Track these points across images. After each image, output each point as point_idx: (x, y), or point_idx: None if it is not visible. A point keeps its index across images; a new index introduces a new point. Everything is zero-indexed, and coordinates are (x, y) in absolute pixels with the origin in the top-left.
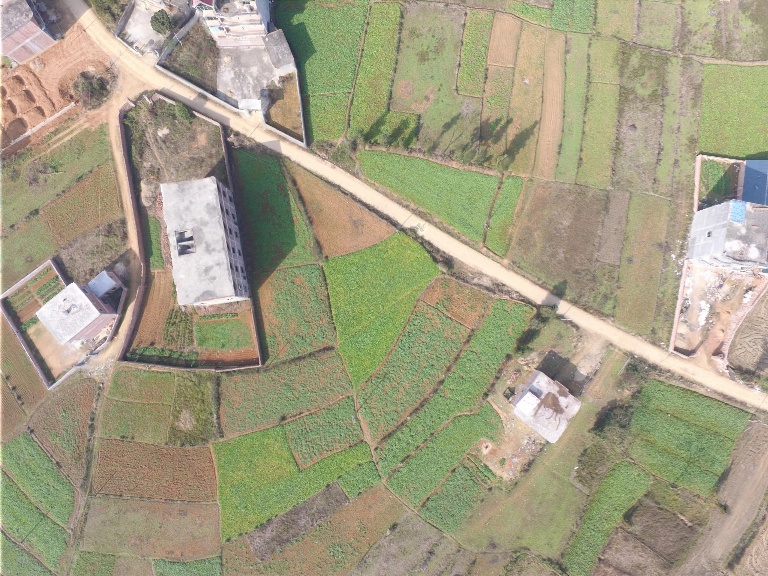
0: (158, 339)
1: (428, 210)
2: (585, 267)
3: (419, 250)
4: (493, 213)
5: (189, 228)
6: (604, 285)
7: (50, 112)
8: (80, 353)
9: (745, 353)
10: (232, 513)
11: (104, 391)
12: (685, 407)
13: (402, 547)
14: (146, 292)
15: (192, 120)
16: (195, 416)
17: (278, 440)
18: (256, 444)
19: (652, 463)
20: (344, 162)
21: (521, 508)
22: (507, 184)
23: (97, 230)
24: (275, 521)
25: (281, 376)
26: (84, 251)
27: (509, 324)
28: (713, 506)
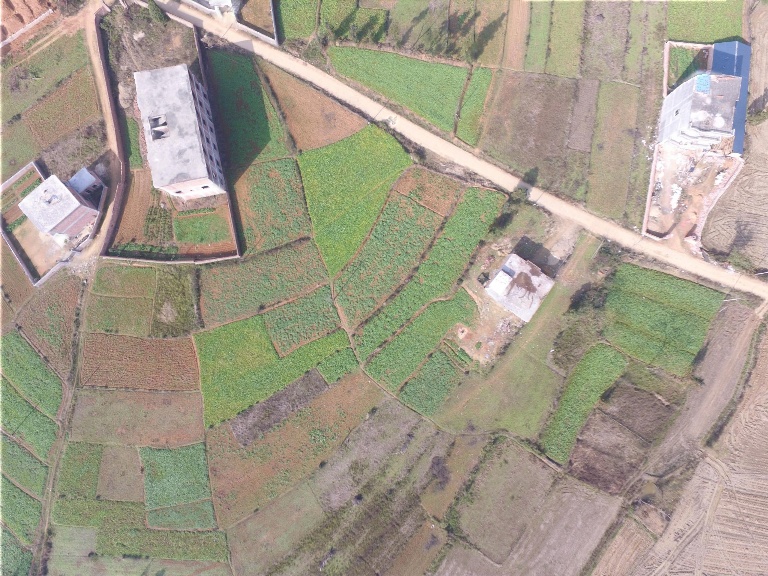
0: (139, 235)
1: (399, 102)
2: (556, 154)
3: (391, 141)
4: (463, 104)
5: (162, 114)
6: (575, 171)
7: (29, 19)
8: (64, 251)
9: (719, 236)
10: (214, 400)
11: (88, 287)
12: (659, 289)
13: (382, 430)
14: (126, 191)
15: (166, 23)
16: (176, 308)
17: (257, 329)
18: (236, 333)
19: (628, 345)
20: (315, 59)
21: (498, 391)
22: (476, 75)
23: (77, 133)
24: (257, 408)
25: (259, 267)
26: (65, 153)
27: (482, 211)
28: (689, 383)
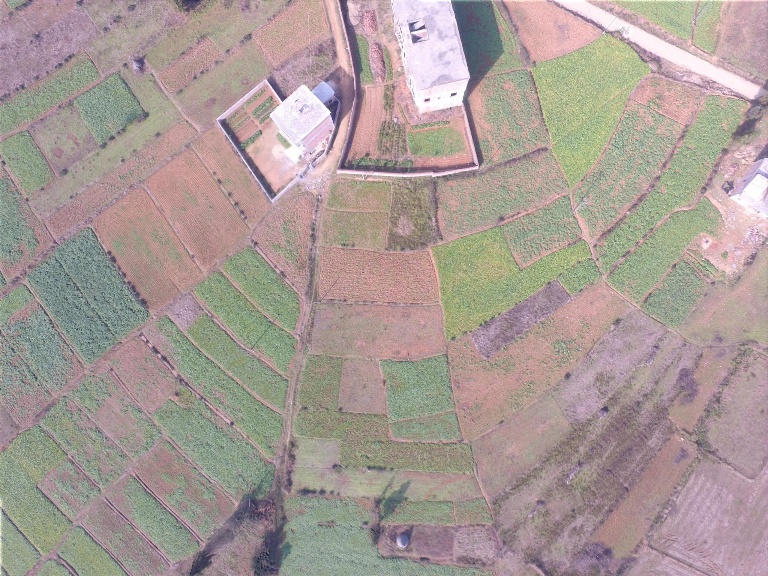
0: (372, 150)
1: (633, 11)
2: None
3: (627, 50)
4: (699, 12)
5: (421, 17)
6: None
7: None
8: (298, 168)
9: None
10: (455, 312)
11: (323, 202)
12: None
13: (627, 342)
14: (358, 107)
15: None
16: (413, 221)
17: (497, 240)
18: (475, 245)
19: None
20: None
21: (746, 302)
22: None
23: (307, 51)
24: (498, 319)
25: (496, 179)
26: (296, 72)
27: (724, 119)
28: None
